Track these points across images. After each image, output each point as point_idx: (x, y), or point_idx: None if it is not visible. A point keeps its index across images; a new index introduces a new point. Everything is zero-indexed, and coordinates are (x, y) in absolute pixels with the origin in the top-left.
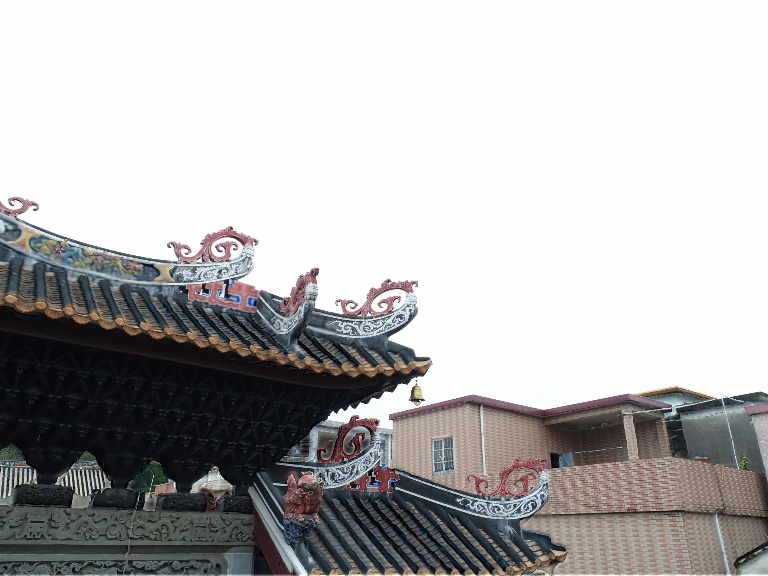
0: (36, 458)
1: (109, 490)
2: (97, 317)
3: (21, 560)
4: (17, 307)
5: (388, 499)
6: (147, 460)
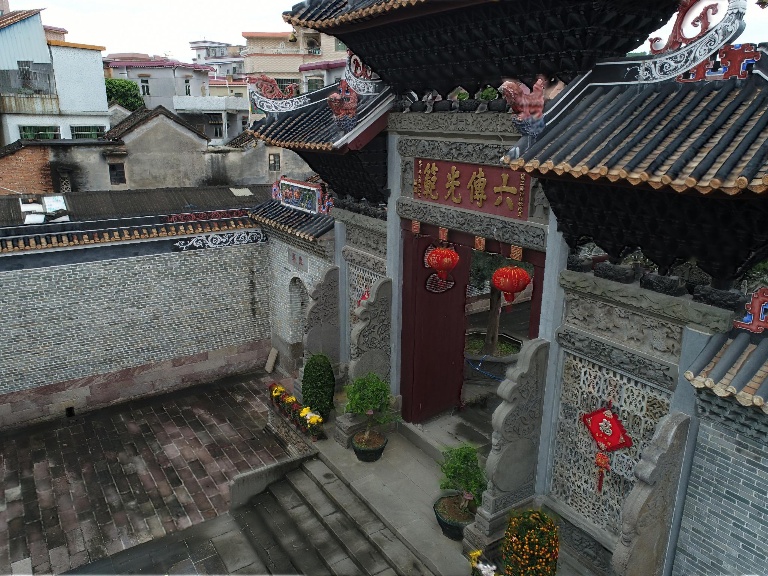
0: (459, 85)
1: (495, 100)
2: (400, 1)
3: (462, 142)
4: (378, 10)
5: (739, 87)
6: (503, 78)
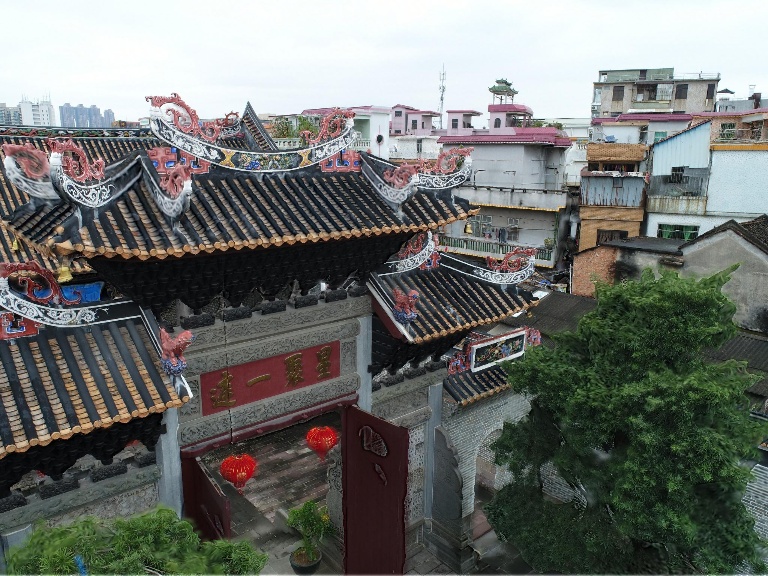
0: None
1: None
2: None
3: None
4: None
5: None
6: None
